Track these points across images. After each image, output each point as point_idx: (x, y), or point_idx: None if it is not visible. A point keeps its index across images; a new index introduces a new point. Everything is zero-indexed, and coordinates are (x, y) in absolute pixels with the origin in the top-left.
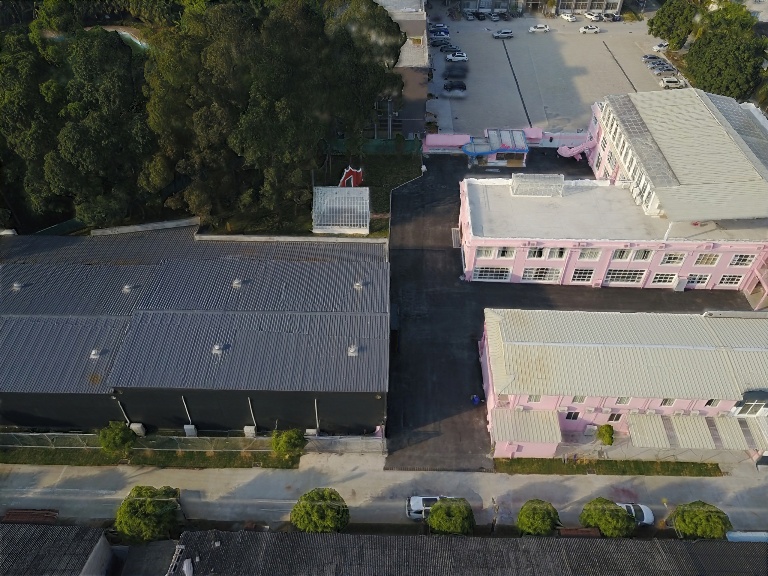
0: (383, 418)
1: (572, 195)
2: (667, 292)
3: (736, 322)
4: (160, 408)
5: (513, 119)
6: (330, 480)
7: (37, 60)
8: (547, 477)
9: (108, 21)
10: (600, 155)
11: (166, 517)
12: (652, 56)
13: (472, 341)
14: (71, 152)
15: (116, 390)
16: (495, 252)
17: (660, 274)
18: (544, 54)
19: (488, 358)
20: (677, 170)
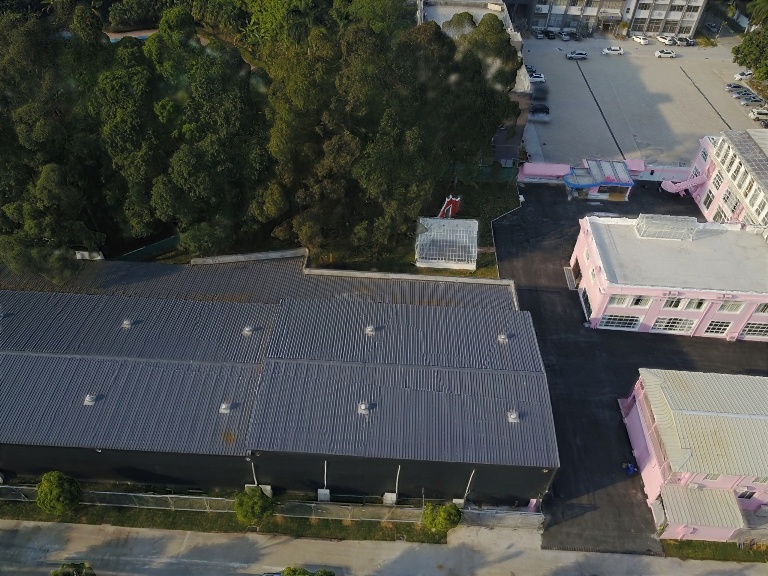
0: (543, 491)
1: (702, 239)
2: None
3: None
4: (296, 471)
5: (603, 147)
6: (484, 559)
7: (153, 76)
8: (723, 564)
9: None
10: (712, 193)
11: None
12: (736, 85)
13: (611, 398)
14: (185, 177)
15: (253, 452)
16: (629, 300)
17: None
18: (622, 78)
19: (645, 424)
20: None
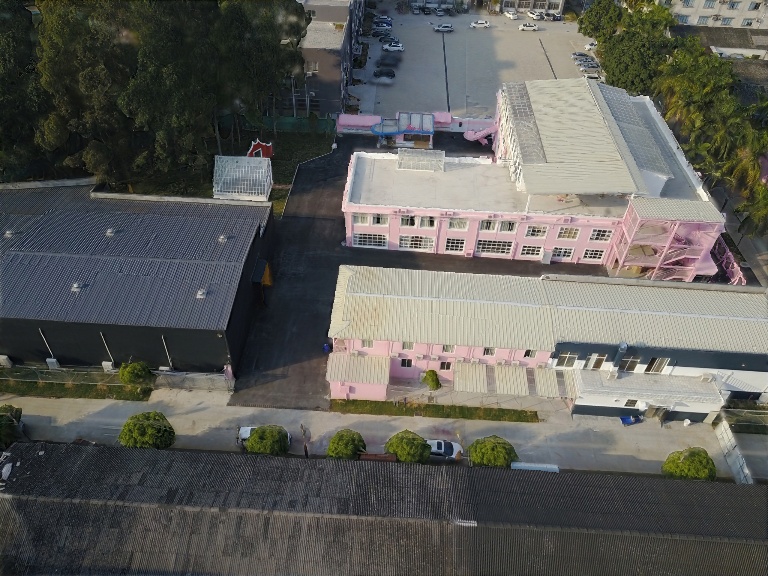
0: (228, 357)
1: (454, 171)
2: (535, 264)
3: (569, 285)
4: (22, 340)
5: (433, 106)
6: (175, 412)
7: None
8: (376, 417)
9: None
10: (499, 139)
11: (2, 430)
12: (580, 54)
13: None
14: None
15: None
16: (370, 219)
17: (527, 246)
18: (479, 48)
19: None
20: (548, 150)
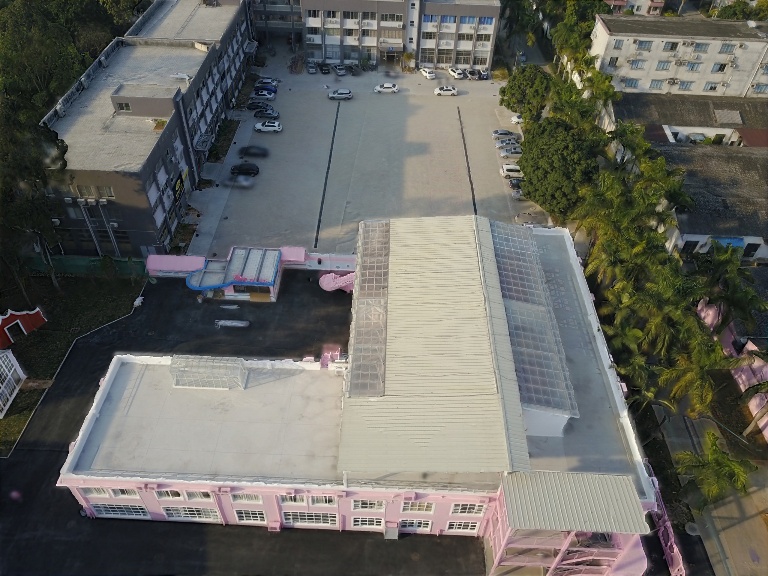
0: None
1: (260, 386)
2: (375, 539)
3: None
4: None
5: (299, 220)
6: None
7: None
8: None
9: None
10: None
11: None
12: (503, 132)
13: None
14: None
15: None
16: (108, 491)
17: (360, 517)
18: (379, 123)
19: None
20: (391, 366)
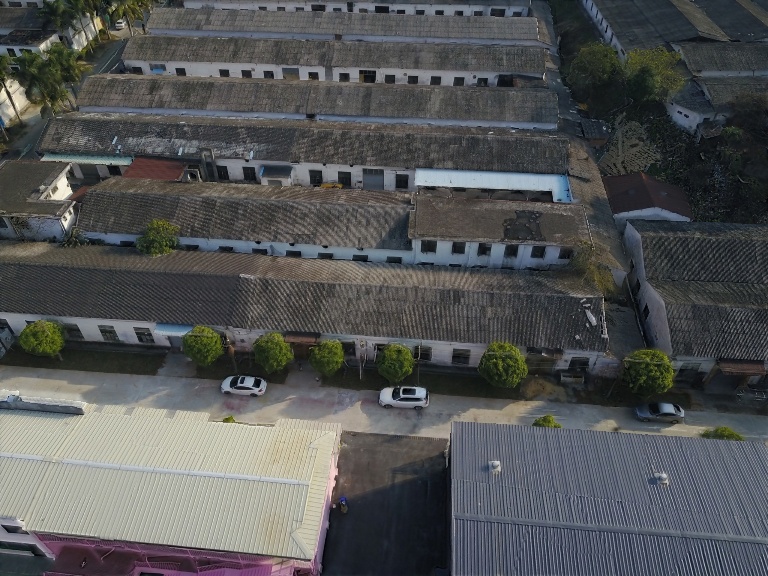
0: None
1: None
2: None
3: None
4: None
5: None
6: None
7: None
8: None
9: None
10: None
11: None
12: None
13: None
14: None
15: None
16: None
17: None
18: None
19: None
20: None
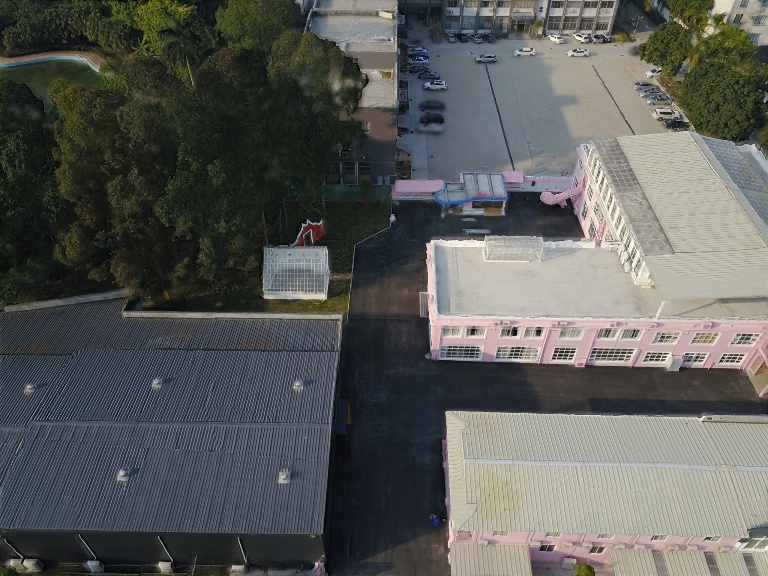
0: (321, 556)
1: (552, 259)
2: (660, 372)
3: (739, 429)
4: (56, 545)
5: (493, 157)
6: None
7: None
8: None
9: (66, 45)
10: (586, 204)
11: None
12: (644, 83)
13: (435, 439)
14: None
15: None
16: (463, 331)
17: (652, 353)
18: (529, 81)
19: None
20: (670, 234)
